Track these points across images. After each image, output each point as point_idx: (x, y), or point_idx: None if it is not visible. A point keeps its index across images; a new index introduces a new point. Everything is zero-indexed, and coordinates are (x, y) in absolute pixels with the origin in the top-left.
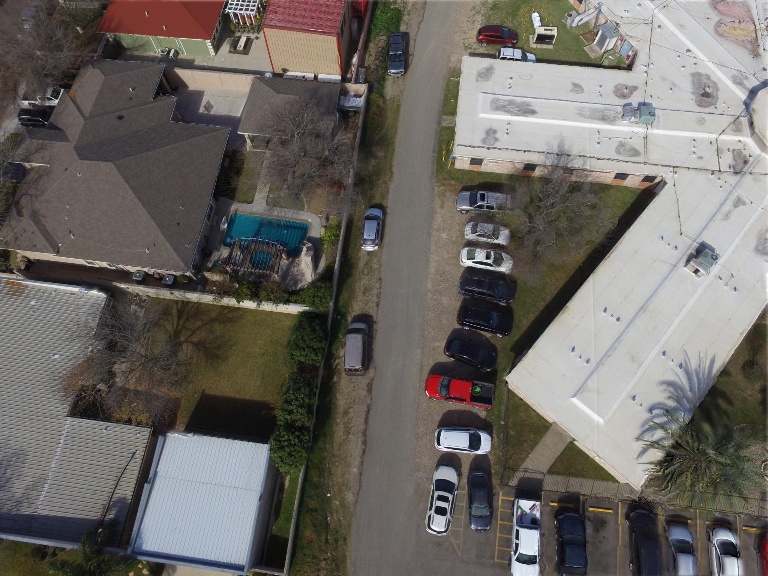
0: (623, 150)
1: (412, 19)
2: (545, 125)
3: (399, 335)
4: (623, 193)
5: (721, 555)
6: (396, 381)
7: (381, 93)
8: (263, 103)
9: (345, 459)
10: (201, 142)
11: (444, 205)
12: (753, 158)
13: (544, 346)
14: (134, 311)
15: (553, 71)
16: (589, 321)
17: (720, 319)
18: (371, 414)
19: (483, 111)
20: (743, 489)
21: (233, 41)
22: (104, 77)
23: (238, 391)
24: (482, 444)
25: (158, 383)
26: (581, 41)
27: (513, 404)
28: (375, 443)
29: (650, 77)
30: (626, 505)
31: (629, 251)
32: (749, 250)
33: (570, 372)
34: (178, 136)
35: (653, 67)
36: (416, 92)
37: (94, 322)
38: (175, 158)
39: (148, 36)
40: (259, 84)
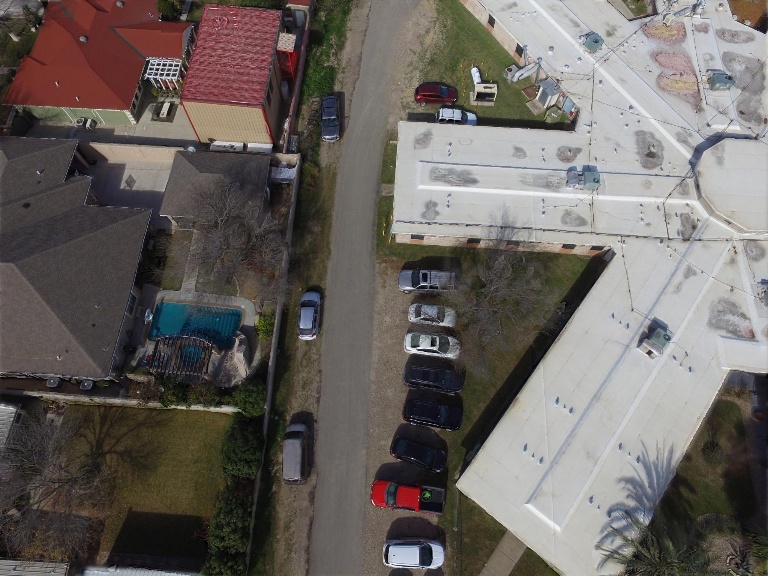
0: (569, 219)
1: (347, 77)
2: (487, 195)
3: (342, 435)
4: (572, 262)
5: None
6: (340, 488)
7: (316, 161)
8: (185, 183)
9: None
10: (118, 229)
11: (386, 284)
12: (701, 222)
13: (495, 445)
14: (50, 421)
15: (494, 134)
16: (541, 414)
17: (676, 403)
18: (314, 528)
19: (422, 182)
20: None
21: (156, 107)
22: (7, 161)
23: (169, 507)
24: (434, 558)
25: (77, 507)
26: (523, 96)
27: (466, 507)
28: (319, 562)
29: (594, 137)
30: None
31: (580, 332)
32: (702, 324)
33: (523, 474)
34: (92, 224)
35: (596, 126)
36: (353, 158)
37: (1, 443)
38: (88, 251)
39: (60, 108)
40: (181, 160)
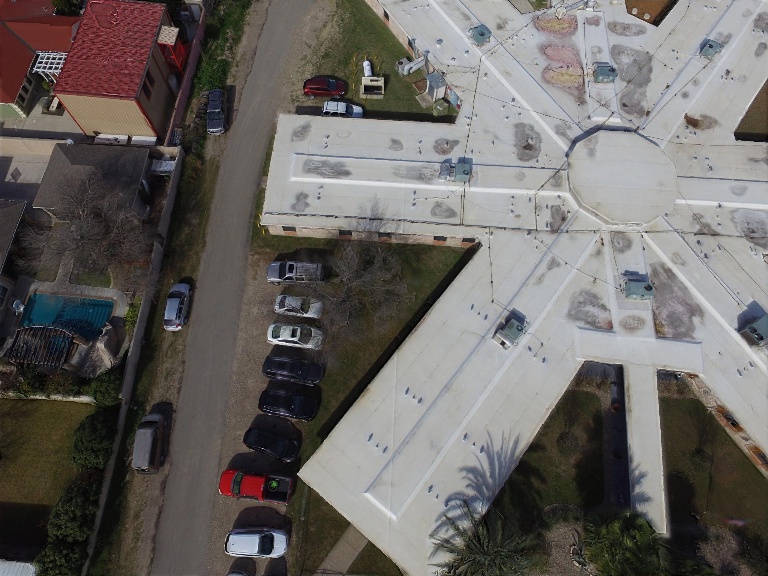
0: (439, 211)
1: (240, 71)
2: (359, 187)
3: (199, 425)
4: (446, 254)
5: None
6: (192, 478)
7: (201, 153)
8: (58, 175)
9: (131, 571)
10: None
11: (257, 276)
12: (571, 214)
13: (340, 435)
14: None
15: (373, 127)
16: (390, 404)
17: (527, 394)
18: (162, 517)
19: (294, 174)
20: None
21: (47, 101)
22: None
23: (25, 496)
24: (275, 547)
25: None
26: (413, 90)
27: (315, 497)
28: (164, 550)
29: (472, 130)
30: None
31: (437, 323)
32: (561, 315)
33: (365, 463)
34: None
35: (476, 119)
36: (237, 151)
37: None
38: None
39: None
40: (58, 152)
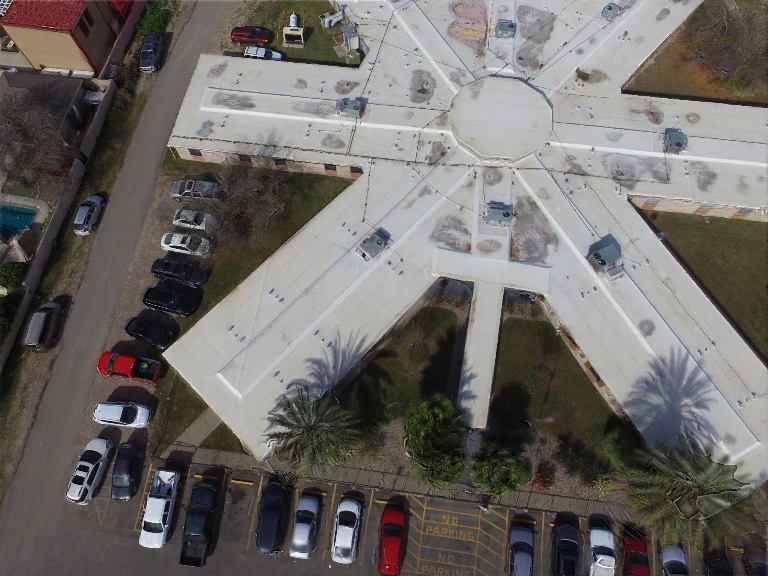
0: (329, 142)
1: (179, 20)
2: (261, 118)
3: (91, 315)
4: (337, 183)
5: (339, 526)
6: (78, 358)
7: (132, 88)
8: None
9: (14, 432)
10: None
11: (163, 193)
12: (451, 150)
13: (205, 325)
14: None
15: (282, 68)
16: (254, 302)
17: (380, 301)
18: (47, 389)
19: (204, 104)
20: (383, 464)
21: (7, 39)
22: None
23: None
24: (137, 418)
25: None
26: (333, 41)
27: (182, 381)
28: (45, 417)
29: (373, 74)
30: (267, 478)
31: (310, 236)
32: (424, 236)
33: (223, 349)
34: None
35: (379, 65)
36: (164, 88)
37: None
38: None
39: None
40: (2, 78)
